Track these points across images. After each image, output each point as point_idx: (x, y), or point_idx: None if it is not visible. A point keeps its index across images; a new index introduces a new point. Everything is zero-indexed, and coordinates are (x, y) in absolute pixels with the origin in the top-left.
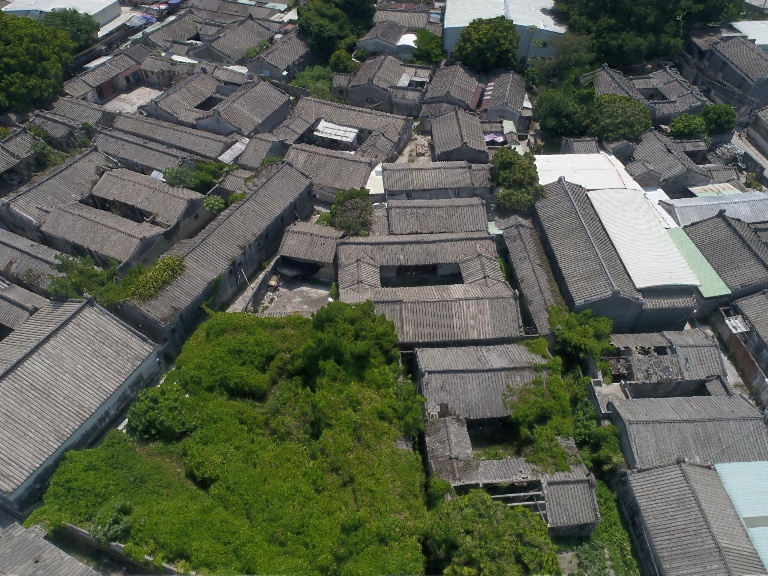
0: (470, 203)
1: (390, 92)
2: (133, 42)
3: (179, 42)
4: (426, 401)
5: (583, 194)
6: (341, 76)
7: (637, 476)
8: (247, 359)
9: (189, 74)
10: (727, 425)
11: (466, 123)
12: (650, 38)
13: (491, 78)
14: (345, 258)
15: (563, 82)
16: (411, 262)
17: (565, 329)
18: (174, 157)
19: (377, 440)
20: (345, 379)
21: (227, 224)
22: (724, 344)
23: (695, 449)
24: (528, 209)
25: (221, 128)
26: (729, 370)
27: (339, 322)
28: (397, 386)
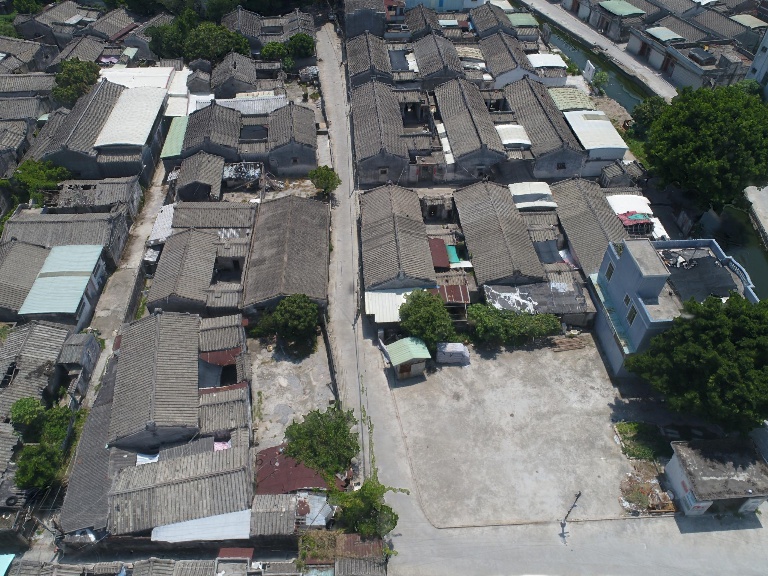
0: None
1: (50, 27)
2: None
3: None
4: None
5: (121, 91)
6: (22, 16)
7: None
8: None
9: None
10: (81, 225)
11: (85, 47)
12: None
13: (150, 18)
14: None
15: (214, 23)
16: None
17: (25, 174)
18: None
19: None
20: None
21: None
22: None
23: (50, 239)
24: (72, 102)
25: None
26: None
27: None
28: None
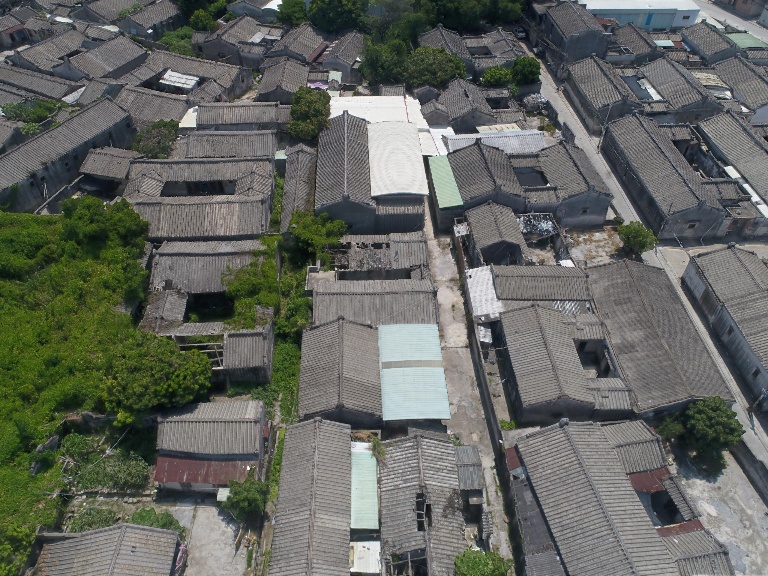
0: (263, 133)
1: (237, 47)
2: (23, 5)
3: (63, 5)
4: (153, 277)
5: (364, 126)
6: (200, 34)
7: (309, 333)
8: (19, 248)
9: (62, 31)
10: (401, 297)
11: (291, 71)
12: (484, 1)
13: (338, 37)
14: (135, 174)
15: None
16: (194, 179)
17: (300, 228)
18: (18, 96)
19: (98, 304)
20: (81, 256)
21: (34, 144)
22: (455, 249)
23: (369, 315)
24: (312, 138)
25: (73, 75)
26: (451, 268)
27: (78, 208)
28: (126, 263)
